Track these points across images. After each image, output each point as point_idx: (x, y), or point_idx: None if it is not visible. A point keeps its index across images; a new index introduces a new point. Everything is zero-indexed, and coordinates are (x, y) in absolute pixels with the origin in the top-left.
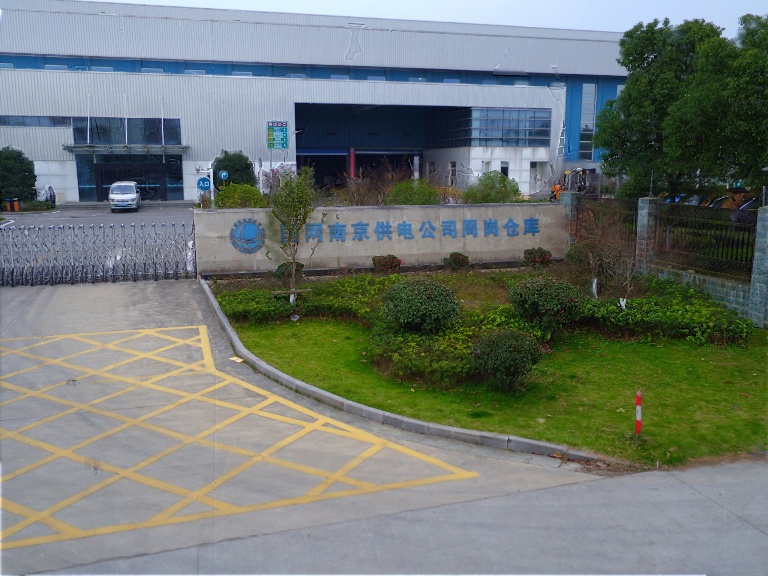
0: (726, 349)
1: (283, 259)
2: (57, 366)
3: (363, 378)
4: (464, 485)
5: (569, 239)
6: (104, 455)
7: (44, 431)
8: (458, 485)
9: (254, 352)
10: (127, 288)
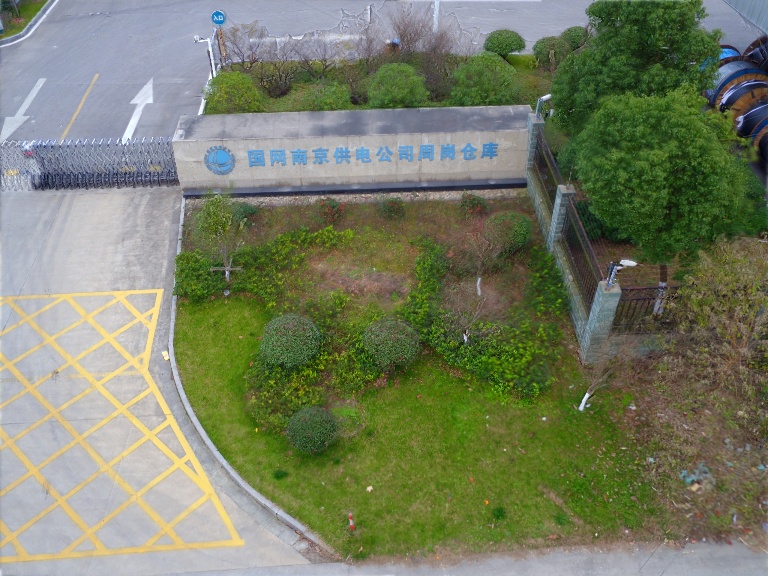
0: (518, 404)
1: (252, 179)
2: (50, 348)
3: (233, 406)
4: (230, 553)
5: (527, 163)
6: (54, 478)
7: (28, 442)
8: (227, 553)
9: (177, 352)
10: (125, 204)
